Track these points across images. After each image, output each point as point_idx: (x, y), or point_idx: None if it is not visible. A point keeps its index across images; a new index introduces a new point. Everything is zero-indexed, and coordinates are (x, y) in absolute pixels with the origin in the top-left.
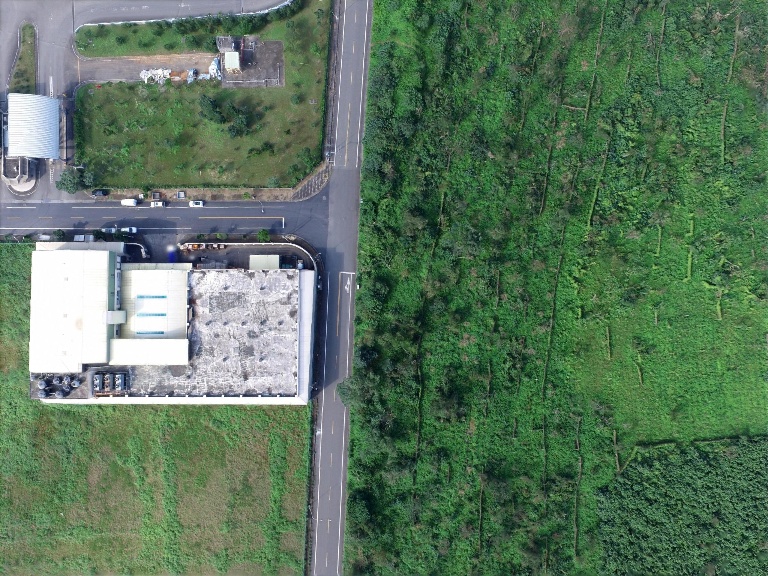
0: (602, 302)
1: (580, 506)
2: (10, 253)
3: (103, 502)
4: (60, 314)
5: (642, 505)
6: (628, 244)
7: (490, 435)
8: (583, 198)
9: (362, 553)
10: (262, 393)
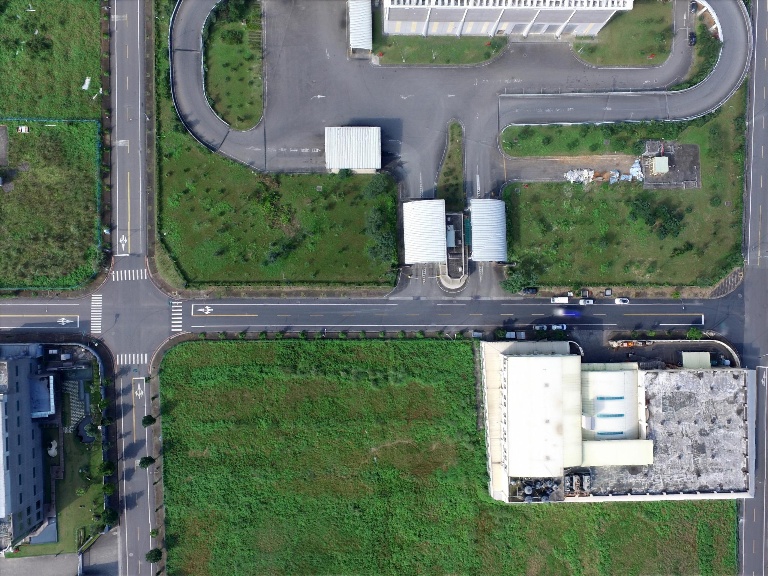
0: None
1: None
2: (444, 350)
3: None
4: (542, 420)
5: None
6: None
7: None
8: None
9: None
10: (714, 489)
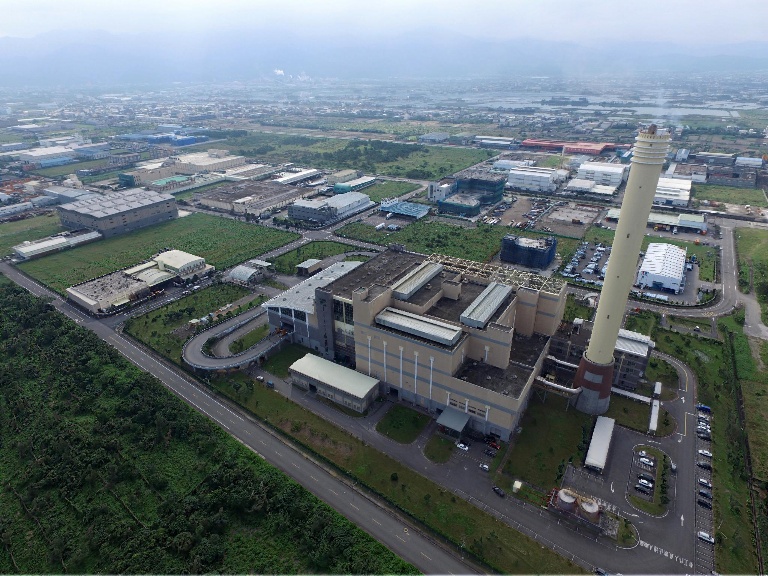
0: None
1: None
2: None
3: None
4: None
5: None
6: None
7: None
8: None
9: None
10: None
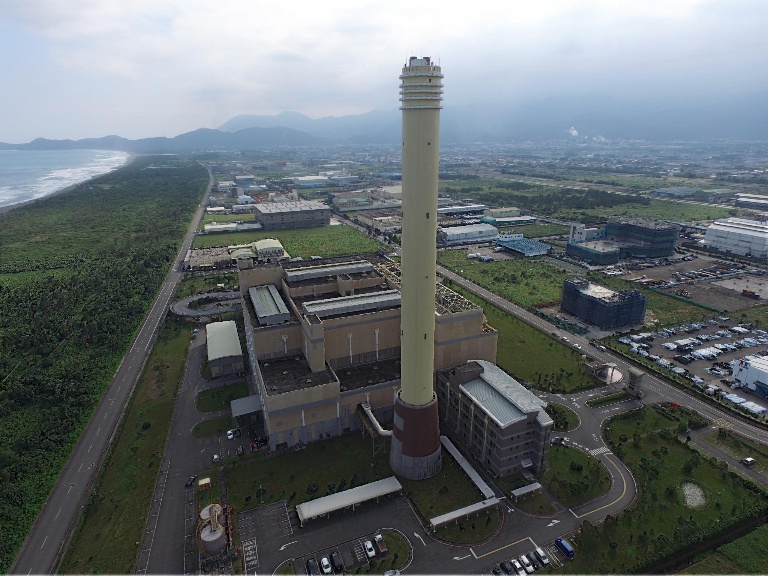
0: None
1: None
2: None
3: None
4: None
5: None
6: None
7: None
8: None
9: None
10: None
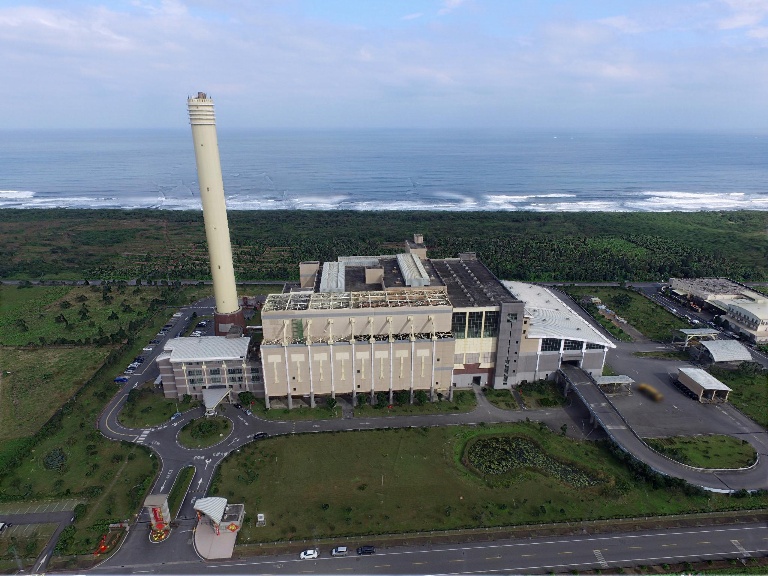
0: None
1: None
2: None
3: None
4: None
5: None
6: None
7: None
8: None
9: (767, 276)
10: None
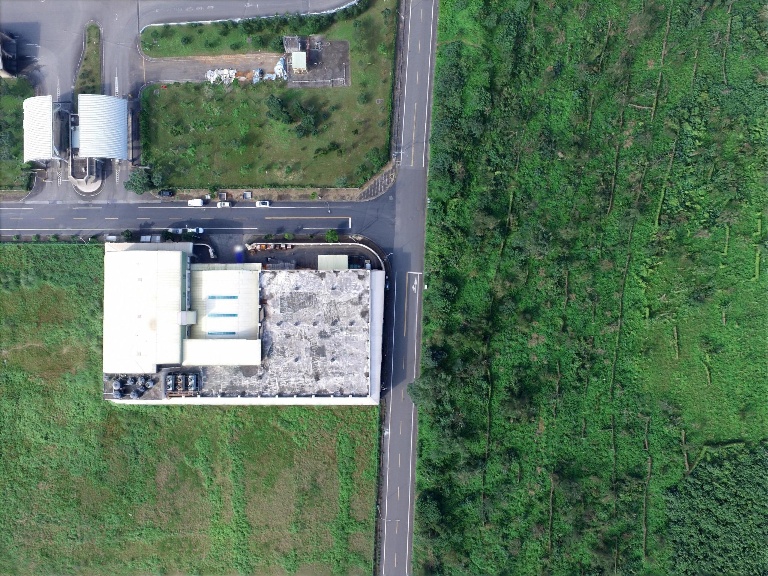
0: (669, 302)
1: (649, 506)
2: (77, 254)
3: (171, 503)
4: (134, 315)
5: (712, 505)
6: (695, 243)
7: (559, 435)
8: (650, 197)
9: (432, 553)
10: (334, 393)
